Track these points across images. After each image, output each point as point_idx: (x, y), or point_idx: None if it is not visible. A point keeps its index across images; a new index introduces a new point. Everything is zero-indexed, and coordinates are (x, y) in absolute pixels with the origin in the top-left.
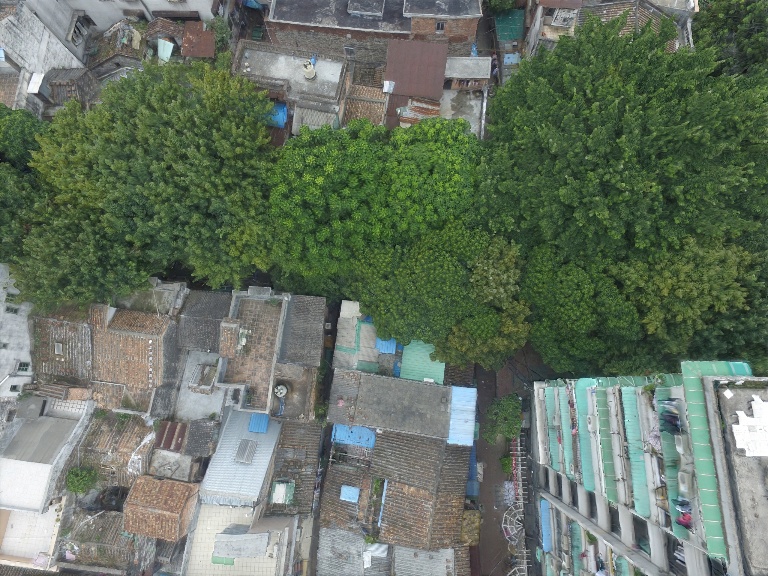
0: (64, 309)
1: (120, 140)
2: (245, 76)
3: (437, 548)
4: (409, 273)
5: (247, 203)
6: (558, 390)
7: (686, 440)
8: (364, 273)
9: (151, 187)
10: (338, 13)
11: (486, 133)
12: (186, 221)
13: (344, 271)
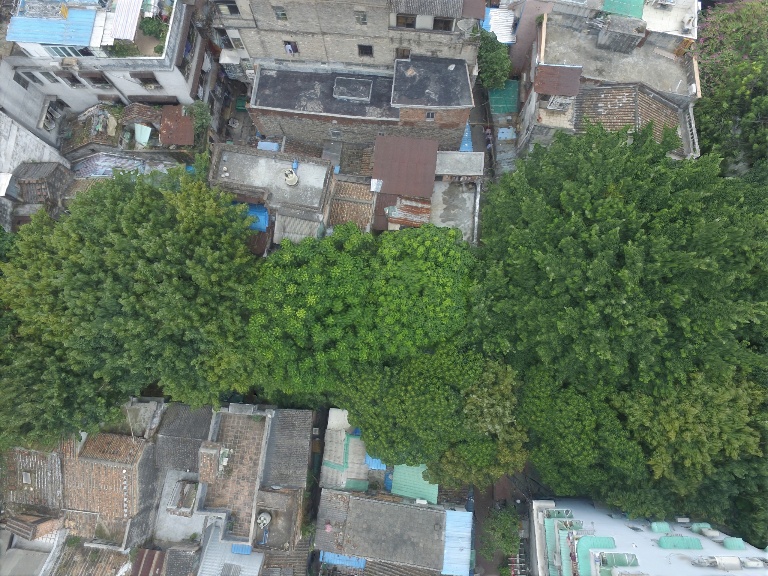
0: None
1: (88, 266)
2: (223, 184)
3: None
4: (398, 402)
5: (225, 328)
6: (559, 534)
7: None
8: (351, 396)
9: (120, 322)
10: (323, 96)
11: (479, 232)
12: (159, 353)
13: None
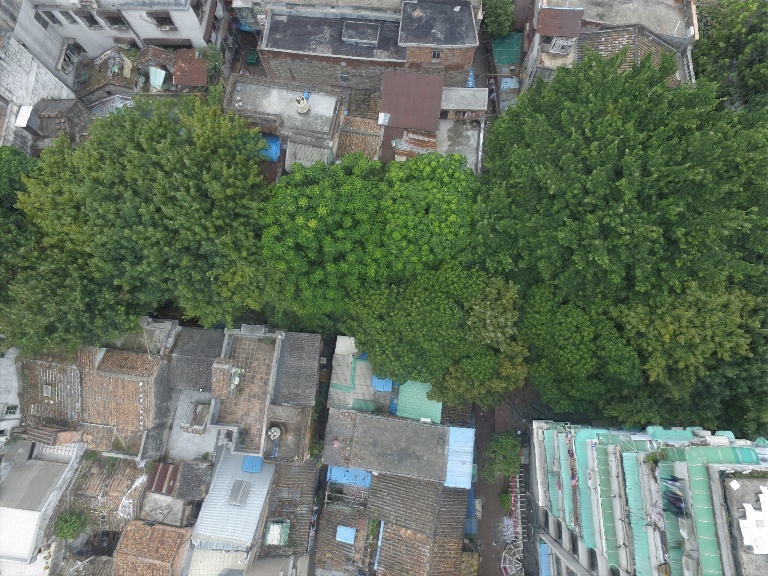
0: (53, 350)
1: (108, 181)
2: (237, 111)
3: None
4: (405, 315)
5: (239, 244)
6: None
7: (690, 525)
8: (359, 313)
9: (140, 231)
10: (332, 40)
11: (483, 165)
12: (176, 264)
13: (339, 309)
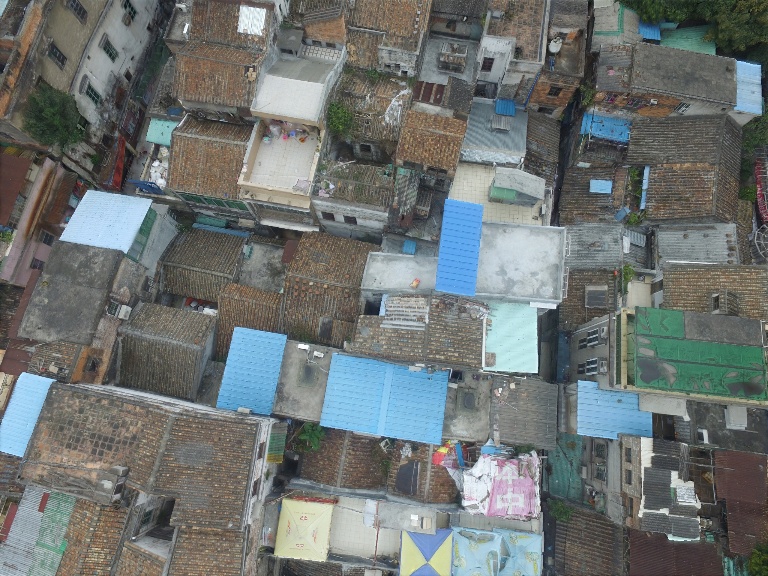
0: None
1: None
2: None
3: (720, 218)
4: None
5: None
6: None
7: None
8: None
9: None
10: None
11: None
12: None
13: None
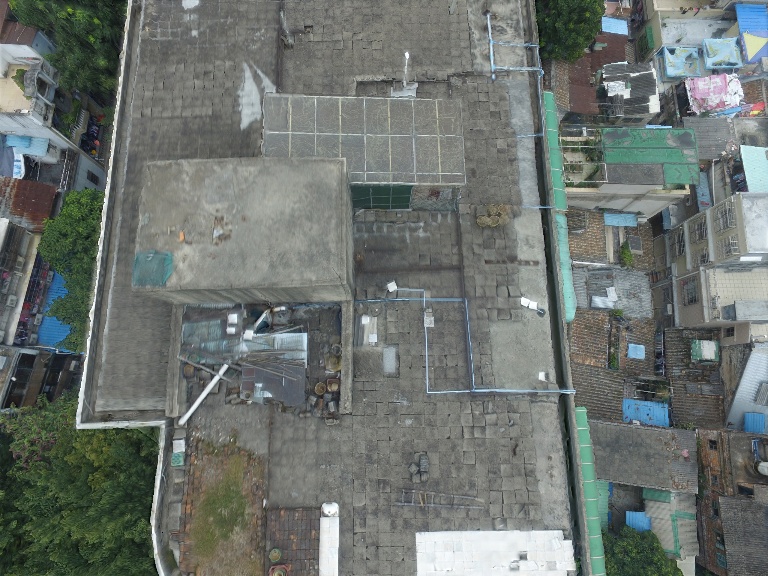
0: None
1: None
2: None
3: None
4: None
5: None
6: None
7: None
8: None
9: None
10: None
11: None
12: None
13: None
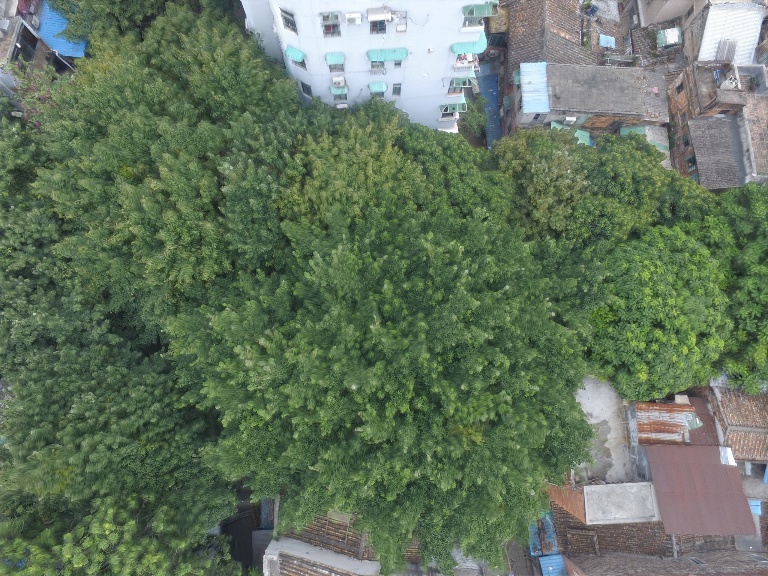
0: None
1: None
2: None
3: None
4: None
5: None
6: None
7: None
8: None
9: None
10: None
11: None
12: None
13: None
